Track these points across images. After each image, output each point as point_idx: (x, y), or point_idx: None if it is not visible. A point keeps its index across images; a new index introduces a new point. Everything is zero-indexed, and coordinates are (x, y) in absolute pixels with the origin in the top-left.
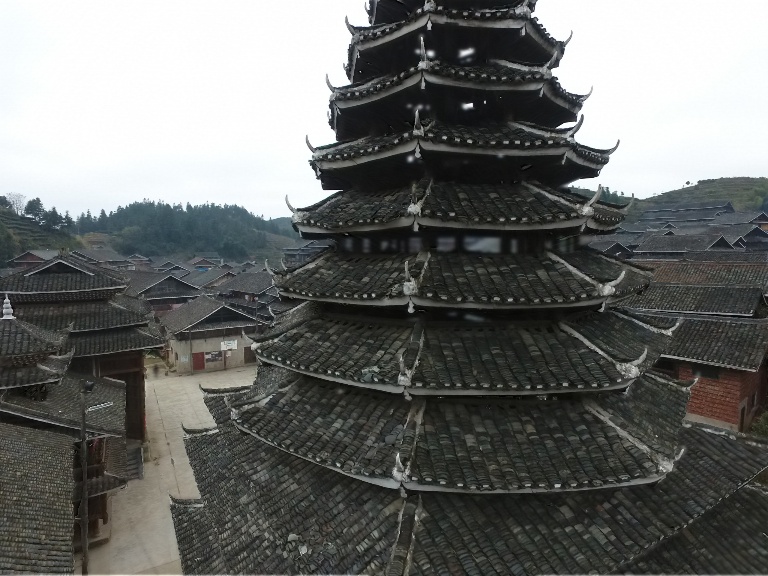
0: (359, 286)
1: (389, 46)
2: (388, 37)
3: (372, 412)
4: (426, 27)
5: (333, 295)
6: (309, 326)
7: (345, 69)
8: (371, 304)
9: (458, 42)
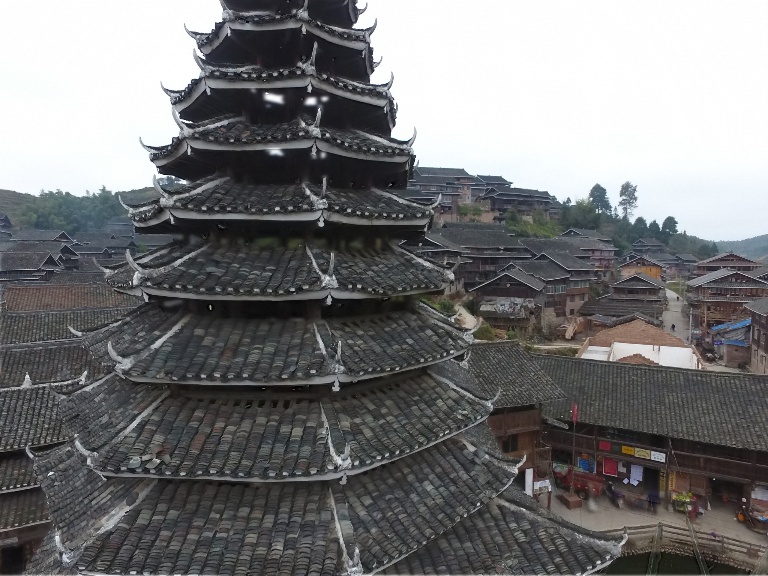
0: (420, 348)
1: (342, 101)
2: (350, 95)
3: (434, 459)
4: (383, 109)
5: (415, 362)
6: (344, 412)
7: (198, 60)
8: (441, 361)
9: (370, 124)
